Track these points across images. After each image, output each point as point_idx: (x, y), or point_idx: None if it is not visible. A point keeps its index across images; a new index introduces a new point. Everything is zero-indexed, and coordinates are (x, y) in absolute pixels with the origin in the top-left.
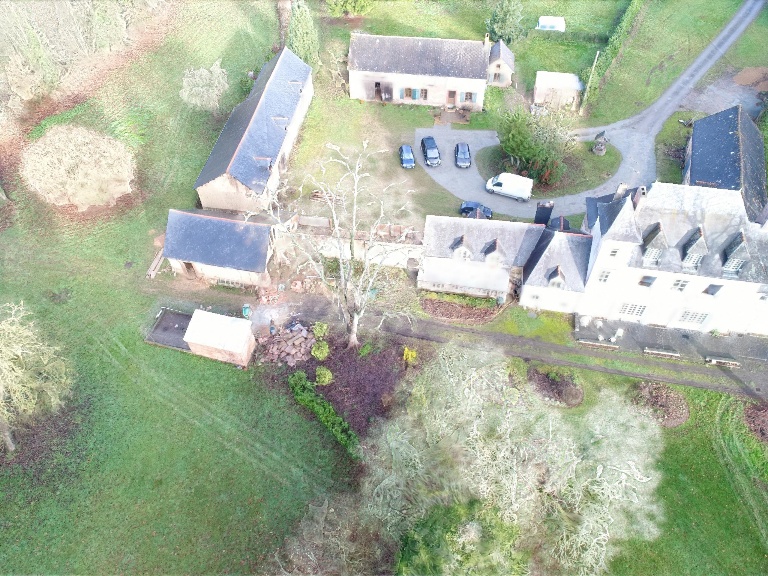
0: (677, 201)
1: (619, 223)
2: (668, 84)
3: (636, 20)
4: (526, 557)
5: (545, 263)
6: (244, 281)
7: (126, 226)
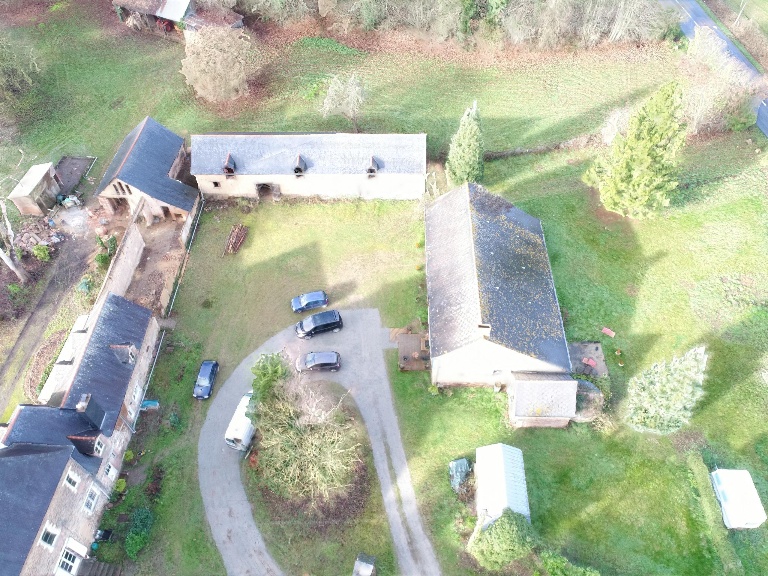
0: None
1: None
2: None
3: None
4: None
5: None
6: None
7: (191, 116)
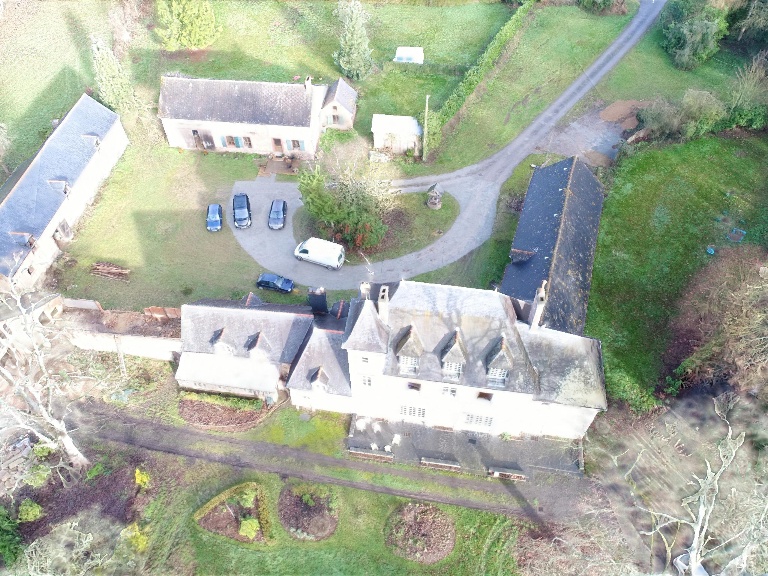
0: (428, 302)
1: (359, 330)
2: (528, 122)
3: (507, 48)
4: None
5: (306, 363)
6: None
7: None
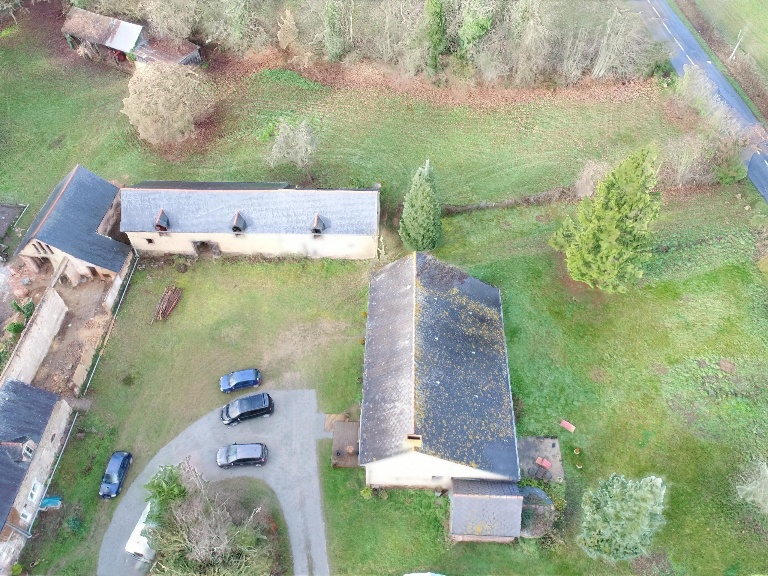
0: None
1: None
2: None
3: None
4: None
5: None
6: None
7: (135, 158)
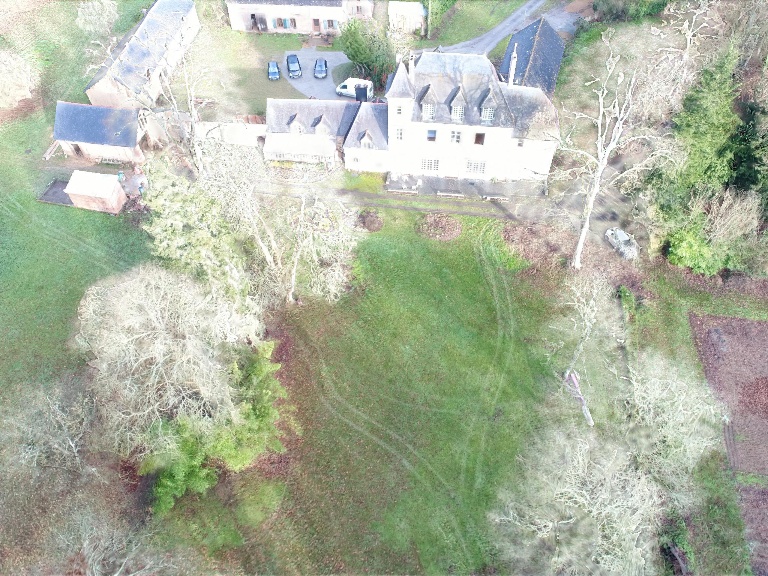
0: (441, 66)
1: (396, 84)
2: (509, 14)
3: None
4: (316, 321)
5: (357, 128)
6: (122, 158)
7: (28, 125)
